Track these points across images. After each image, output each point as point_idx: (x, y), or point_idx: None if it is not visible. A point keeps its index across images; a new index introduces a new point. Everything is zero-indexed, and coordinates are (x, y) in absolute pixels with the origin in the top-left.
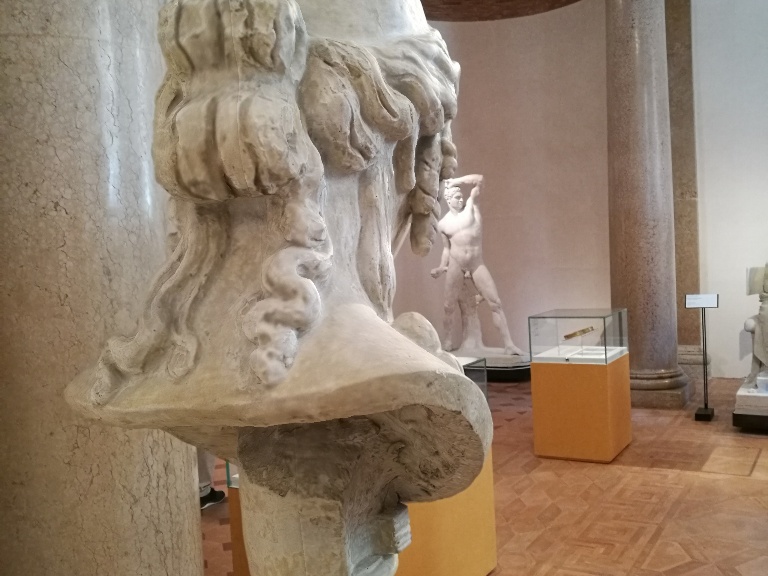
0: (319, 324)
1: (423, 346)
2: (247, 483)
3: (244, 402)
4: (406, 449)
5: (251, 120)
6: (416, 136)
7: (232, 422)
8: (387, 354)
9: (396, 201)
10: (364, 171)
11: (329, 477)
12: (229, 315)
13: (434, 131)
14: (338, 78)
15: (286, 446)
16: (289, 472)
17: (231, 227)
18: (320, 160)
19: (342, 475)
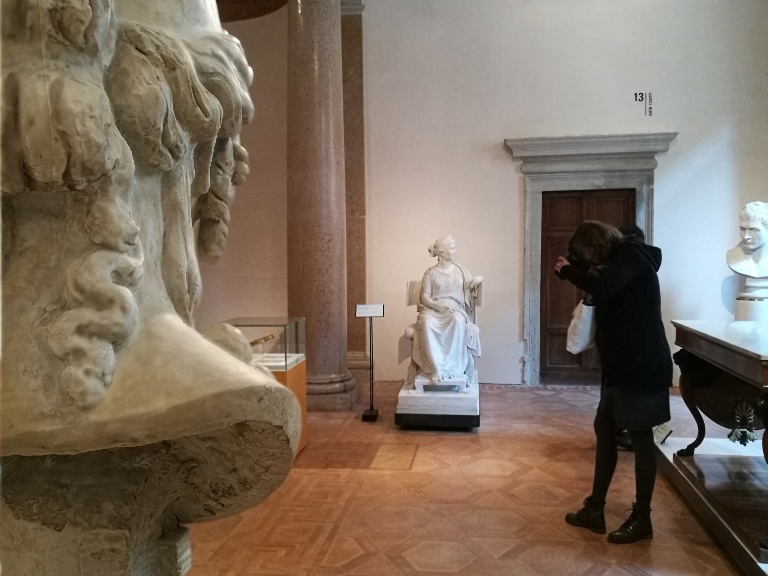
0: (136, 337)
1: None
2: (11, 519)
3: (53, 427)
4: (196, 468)
5: (66, 105)
6: (215, 138)
7: (30, 451)
8: (217, 369)
9: None
10: (168, 171)
11: (114, 505)
12: (20, 326)
13: (231, 134)
14: (152, 68)
15: (61, 474)
16: (66, 503)
17: (16, 224)
18: (131, 156)
19: (129, 501)
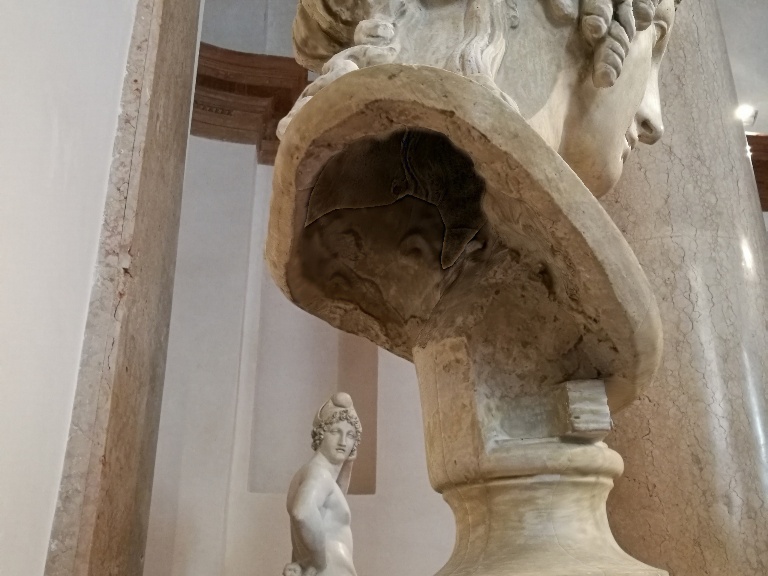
0: None
1: None
2: None
3: None
4: (552, 275)
5: None
6: None
7: (287, 204)
8: None
9: (555, 35)
10: None
11: (463, 317)
12: None
13: None
14: None
15: None
16: (435, 324)
17: None
18: None
19: (475, 312)
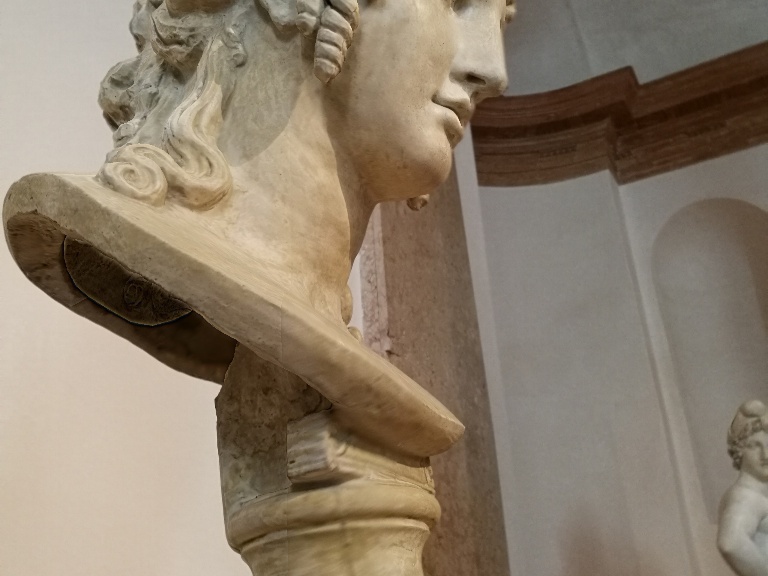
0: None
1: None
2: None
3: None
4: None
5: None
6: None
7: None
8: None
9: (289, 49)
10: None
11: None
12: None
13: None
14: None
15: None
16: None
17: None
18: None
19: None
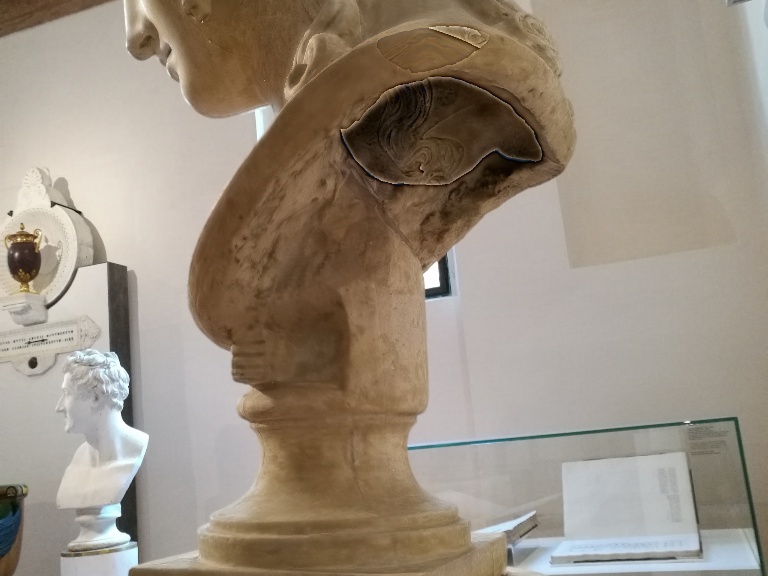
0: None
1: (452, 163)
2: (411, 256)
3: None
4: None
5: None
6: None
7: None
8: (524, 147)
9: None
10: None
11: None
12: None
13: None
14: None
15: None
16: None
17: None
18: None
19: None
